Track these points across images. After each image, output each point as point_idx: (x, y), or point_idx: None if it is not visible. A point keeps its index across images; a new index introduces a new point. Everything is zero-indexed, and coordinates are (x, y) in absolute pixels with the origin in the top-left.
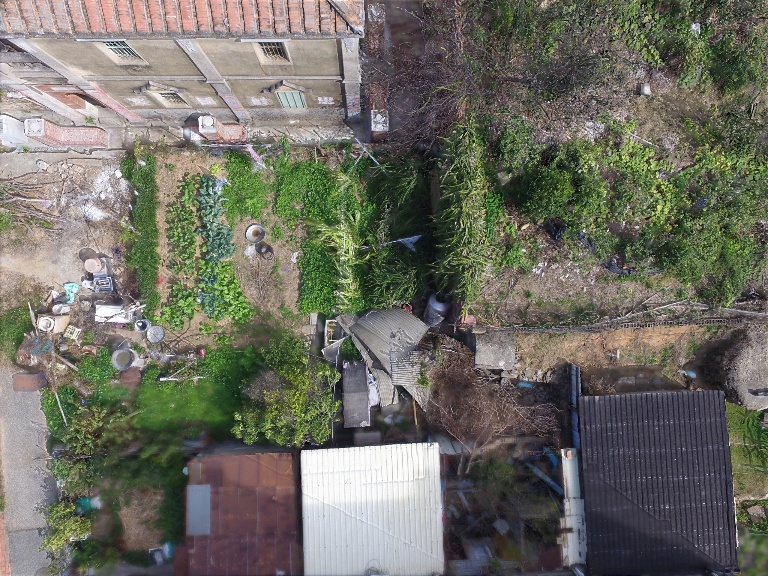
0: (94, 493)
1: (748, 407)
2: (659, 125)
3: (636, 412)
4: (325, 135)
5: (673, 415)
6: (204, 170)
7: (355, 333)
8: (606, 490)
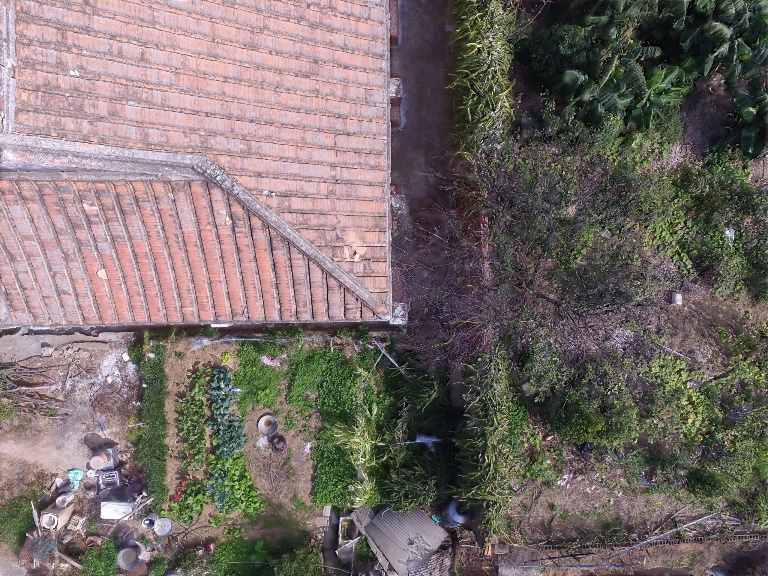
0: None
1: None
2: (691, 335)
3: None
4: None
5: None
6: (215, 358)
7: (371, 536)
8: None
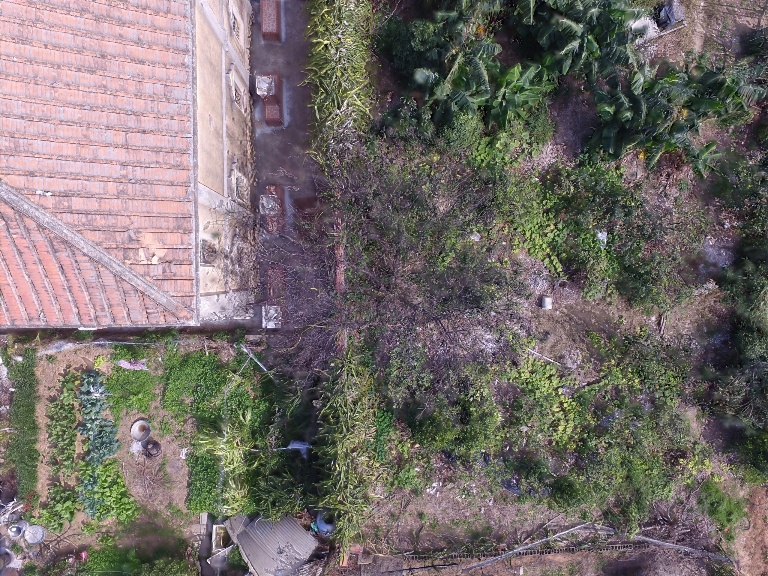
0: None
1: None
2: (561, 340)
3: None
4: (223, 314)
5: None
6: (87, 361)
7: (241, 545)
8: None
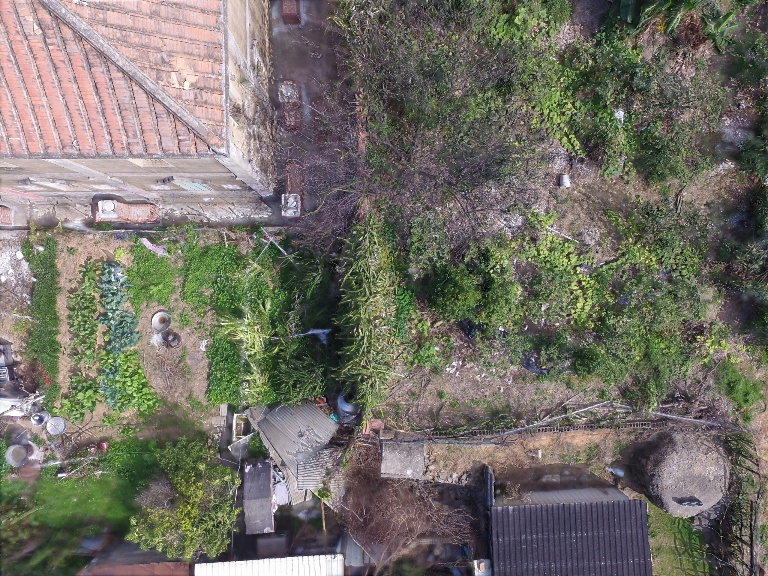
0: None
1: (673, 515)
2: (579, 218)
3: (552, 523)
4: (241, 213)
5: (592, 526)
6: (108, 254)
7: (262, 430)
8: None
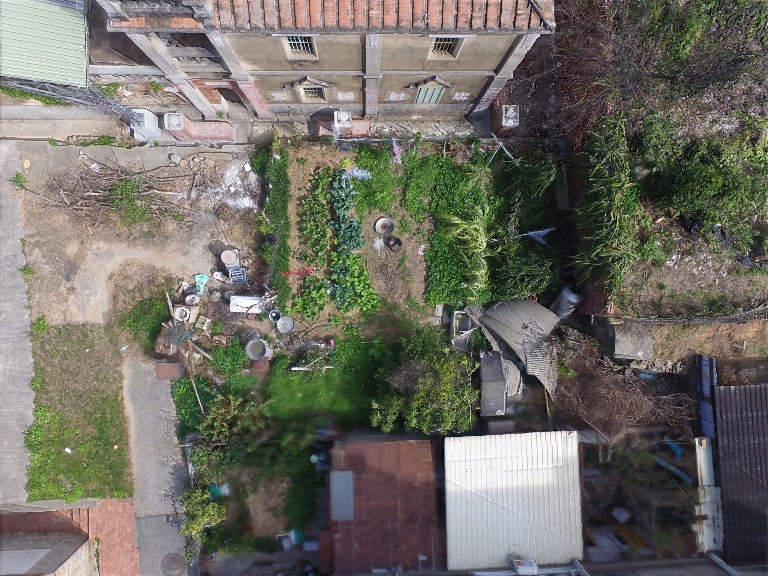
0: (222, 480)
1: None
2: None
3: None
4: (446, 130)
5: None
6: (334, 164)
7: (486, 324)
8: (742, 478)
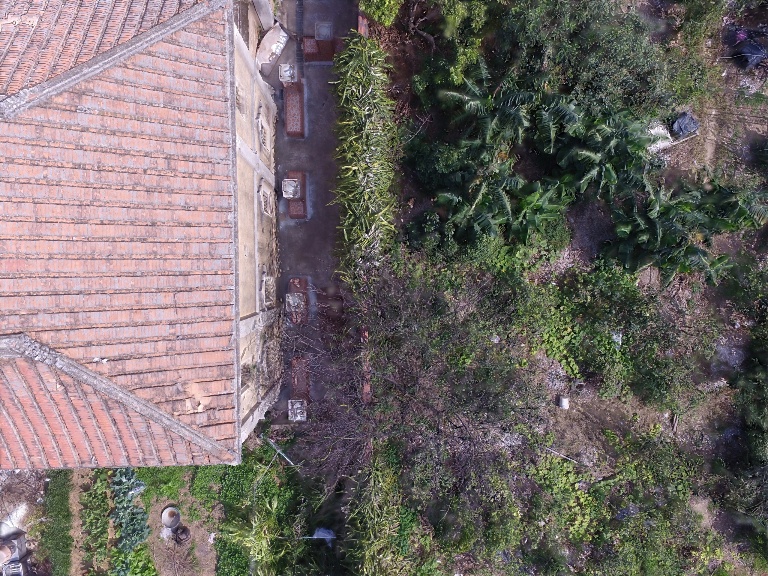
0: None
1: None
2: (578, 439)
3: None
4: None
5: None
6: None
7: None
8: None
